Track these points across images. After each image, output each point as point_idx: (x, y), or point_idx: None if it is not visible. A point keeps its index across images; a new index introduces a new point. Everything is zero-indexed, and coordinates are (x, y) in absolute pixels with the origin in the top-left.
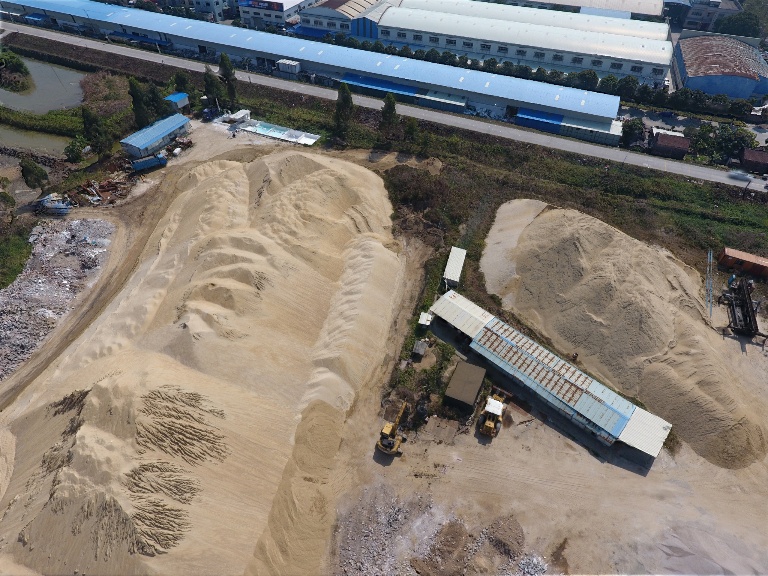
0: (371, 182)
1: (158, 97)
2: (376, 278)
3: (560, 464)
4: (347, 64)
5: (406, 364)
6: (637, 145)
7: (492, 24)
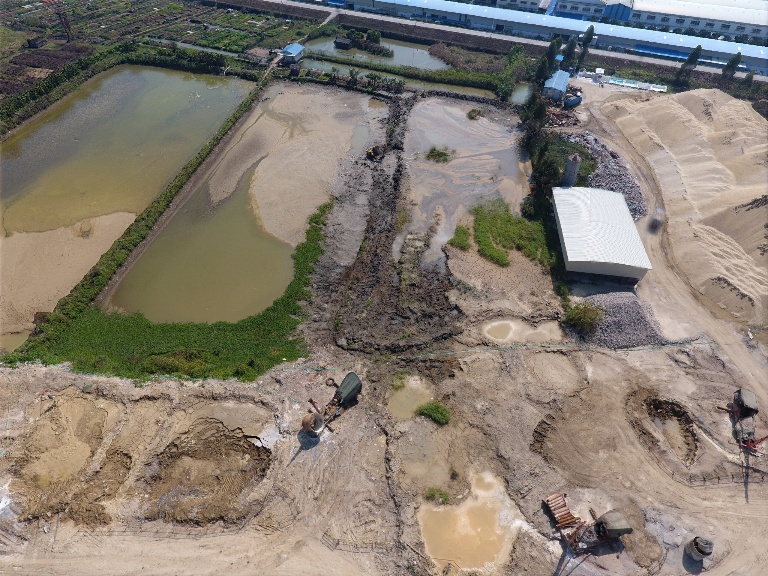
0: None
1: None
2: None
3: None
4: (640, 38)
5: None
6: None
7: (728, 9)
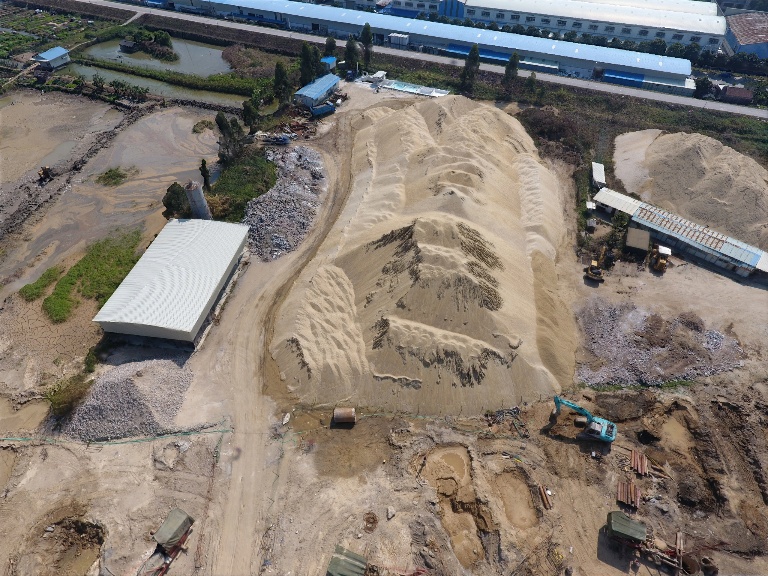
0: (513, 120)
1: (318, 59)
2: (544, 181)
3: (715, 286)
4: (452, 36)
5: (585, 234)
6: (709, 97)
7: (566, 3)
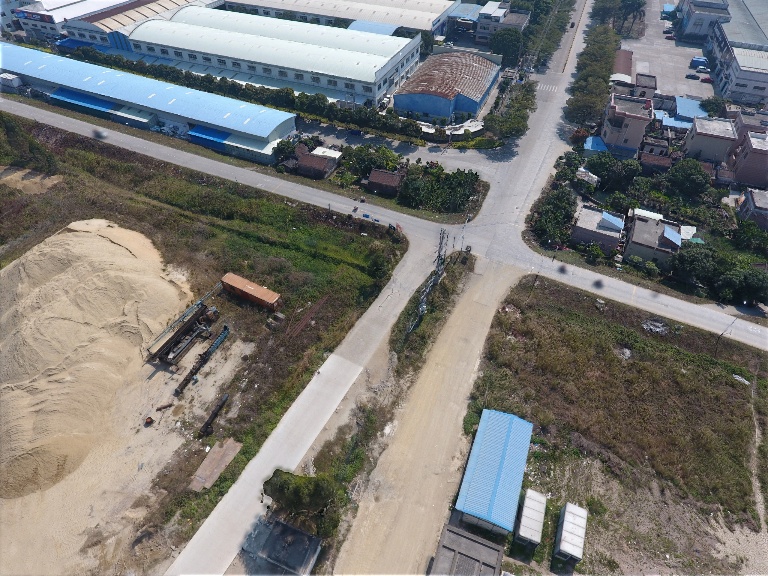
0: None
1: None
2: None
3: None
4: (57, 79)
5: None
6: (283, 164)
7: (232, 39)
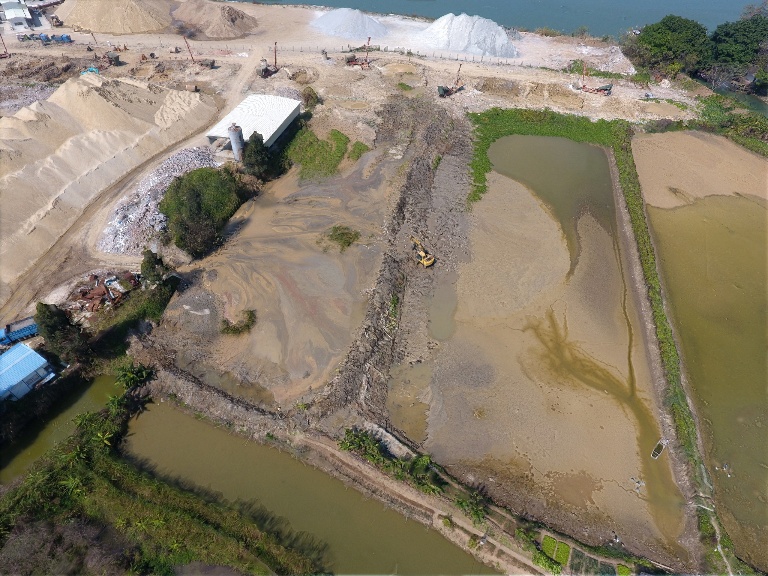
0: None
1: None
2: None
3: None
4: None
5: None
6: None
7: None
